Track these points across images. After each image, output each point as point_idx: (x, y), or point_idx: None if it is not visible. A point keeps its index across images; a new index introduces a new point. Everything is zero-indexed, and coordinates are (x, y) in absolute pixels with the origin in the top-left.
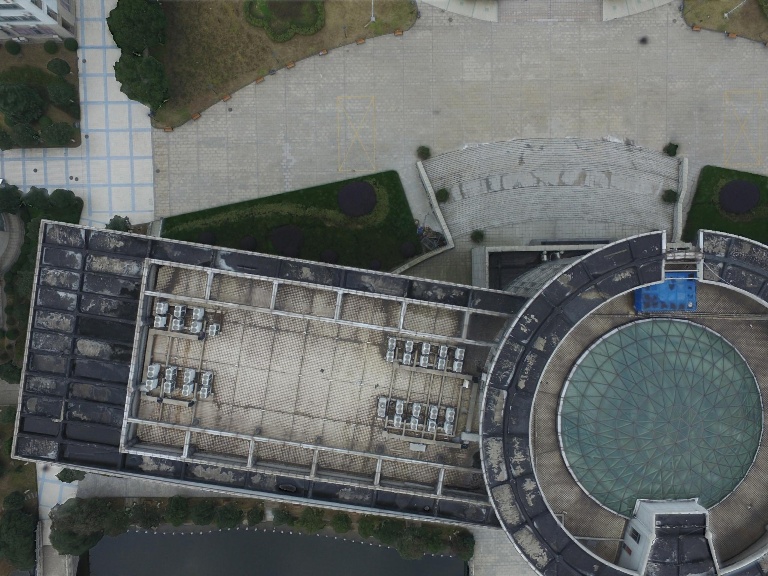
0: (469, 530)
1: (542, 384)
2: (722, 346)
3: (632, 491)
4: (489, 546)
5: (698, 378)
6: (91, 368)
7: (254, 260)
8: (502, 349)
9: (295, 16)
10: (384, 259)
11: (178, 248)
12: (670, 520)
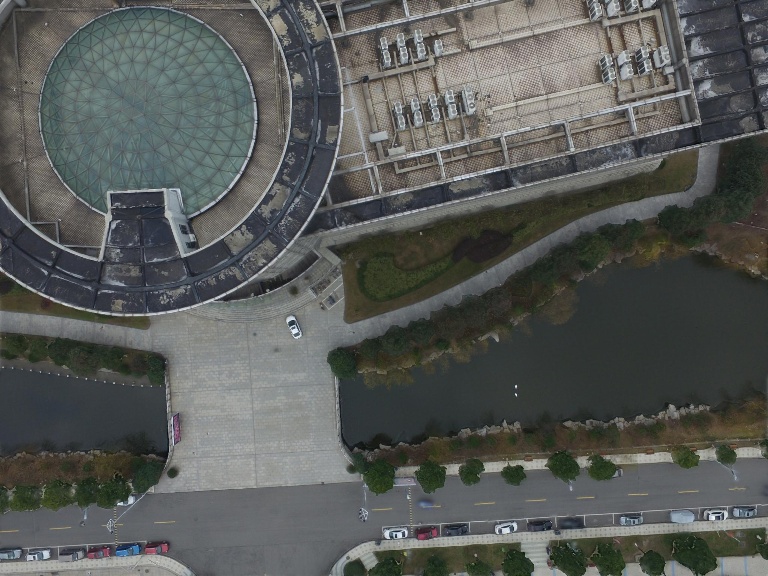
0: (164, 355)
1: (27, 84)
2: (201, 31)
3: (106, 182)
4: (185, 371)
5: (159, 55)
6: None
7: None
8: None
9: None
10: None
11: None
12: (130, 201)
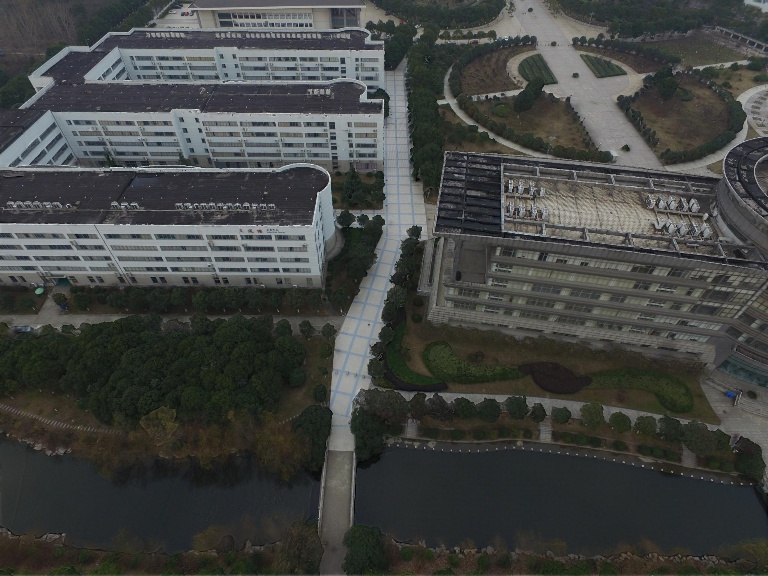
0: None
1: None
2: None
3: None
4: None
5: None
6: (476, 201)
7: (558, 167)
8: (725, 168)
9: None
10: None
11: (516, 163)
12: None
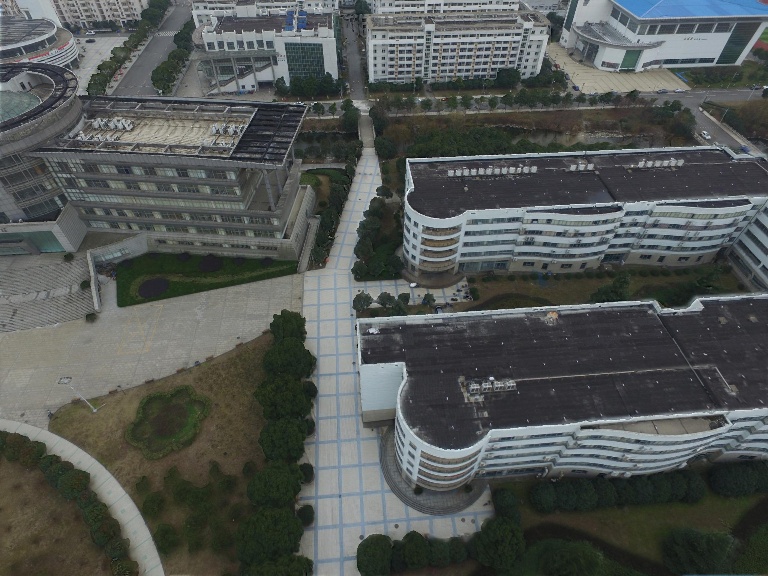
0: None
1: None
2: None
3: None
4: None
5: None
6: None
7: None
8: None
9: (165, 406)
10: (146, 259)
11: None
12: None
